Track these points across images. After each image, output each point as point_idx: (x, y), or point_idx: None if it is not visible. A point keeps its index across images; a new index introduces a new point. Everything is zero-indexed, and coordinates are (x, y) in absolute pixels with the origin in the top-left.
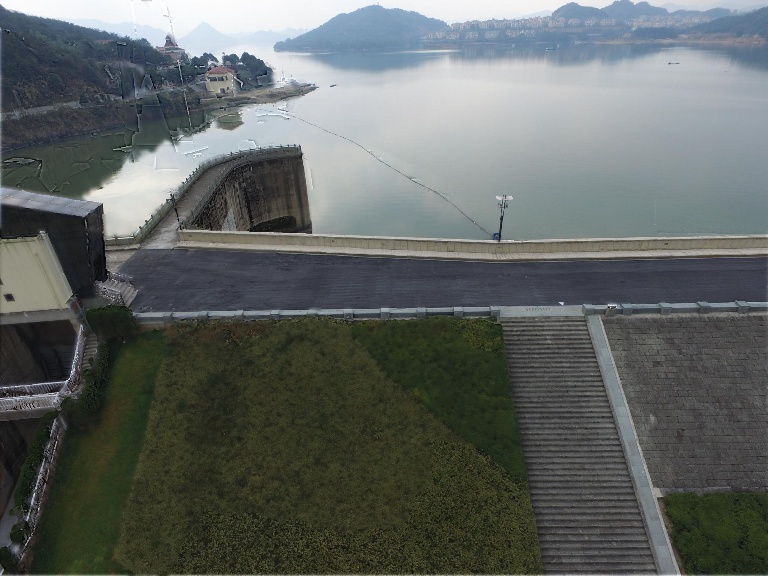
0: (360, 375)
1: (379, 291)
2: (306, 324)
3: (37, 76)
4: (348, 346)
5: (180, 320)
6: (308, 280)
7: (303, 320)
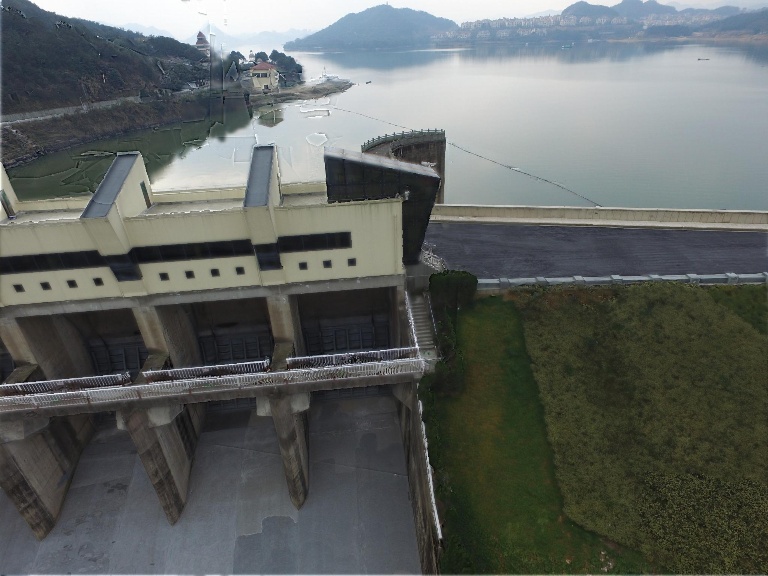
0: (741, 338)
1: (693, 259)
2: (660, 288)
3: (98, 71)
4: (715, 310)
5: (519, 286)
6: (604, 249)
7: (655, 284)
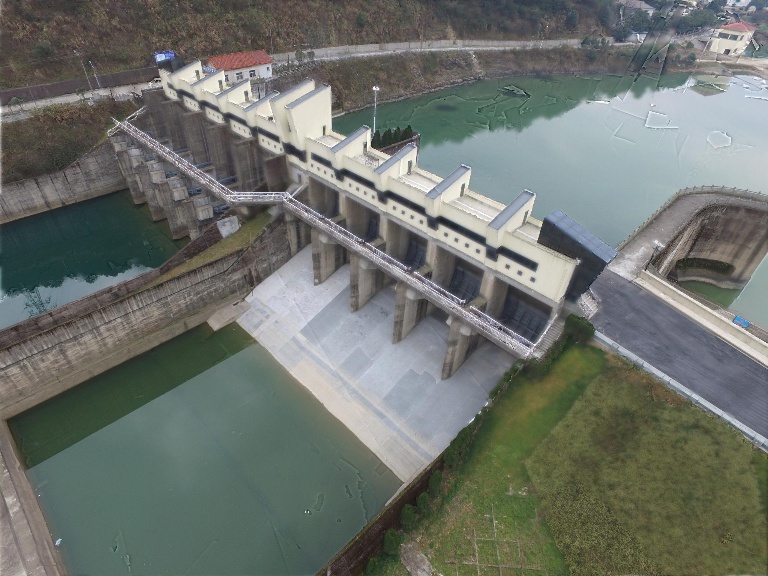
0: (738, 491)
1: None
2: (716, 424)
3: (562, 11)
4: (742, 464)
5: (622, 355)
6: (734, 382)
7: (716, 419)
